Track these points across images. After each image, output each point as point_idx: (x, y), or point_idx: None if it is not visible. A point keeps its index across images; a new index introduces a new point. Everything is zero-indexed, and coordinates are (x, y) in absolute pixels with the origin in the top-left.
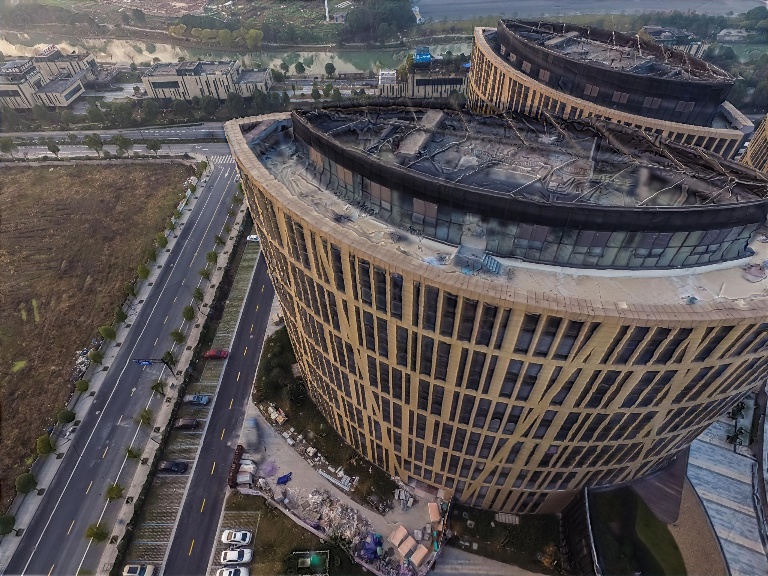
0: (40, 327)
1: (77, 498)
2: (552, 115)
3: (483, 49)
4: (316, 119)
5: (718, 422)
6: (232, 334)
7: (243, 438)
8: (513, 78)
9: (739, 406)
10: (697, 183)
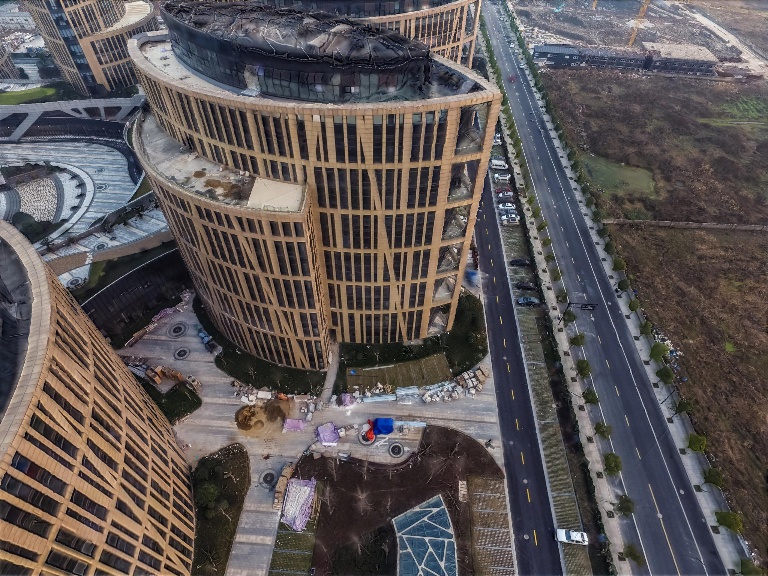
0: (761, 389)
1: (576, 256)
2: None
3: (5, 458)
4: (407, 43)
5: (152, 217)
6: (527, 362)
7: (478, 277)
8: (55, 333)
9: (136, 209)
10: (203, 3)
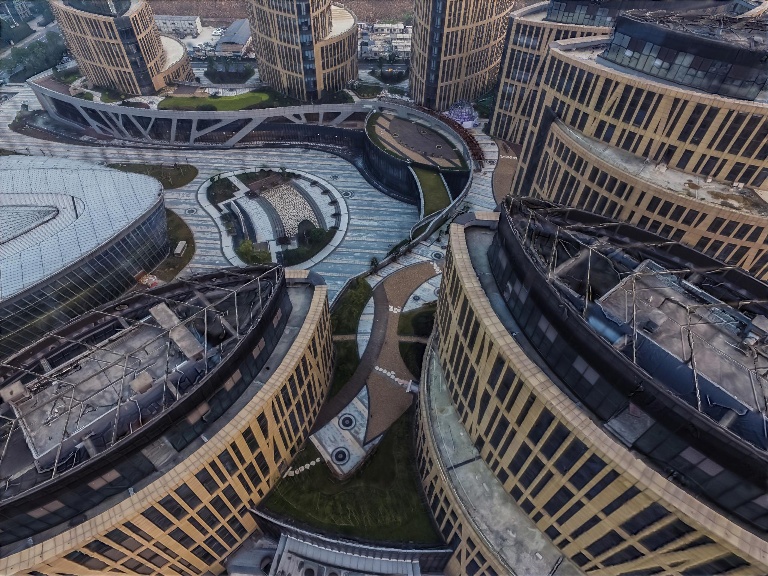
0: None
1: None
2: (764, 50)
3: None
4: None
5: None
6: None
7: None
8: None
9: None
10: None
